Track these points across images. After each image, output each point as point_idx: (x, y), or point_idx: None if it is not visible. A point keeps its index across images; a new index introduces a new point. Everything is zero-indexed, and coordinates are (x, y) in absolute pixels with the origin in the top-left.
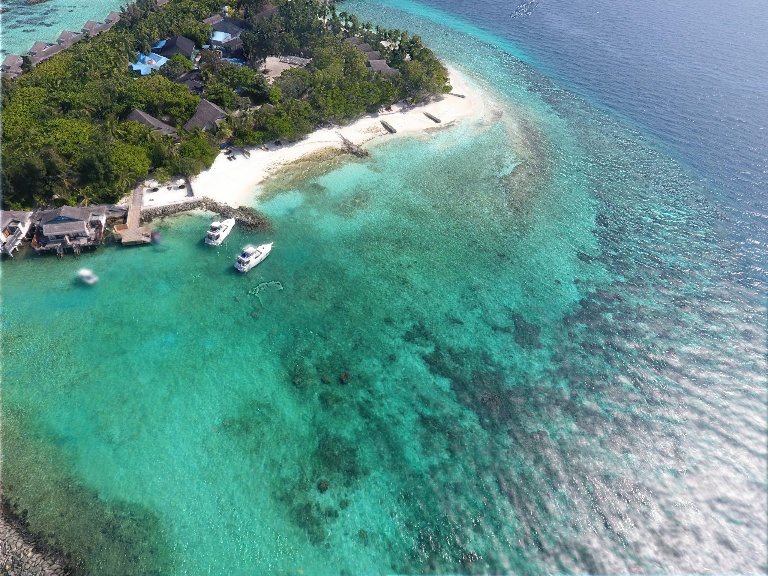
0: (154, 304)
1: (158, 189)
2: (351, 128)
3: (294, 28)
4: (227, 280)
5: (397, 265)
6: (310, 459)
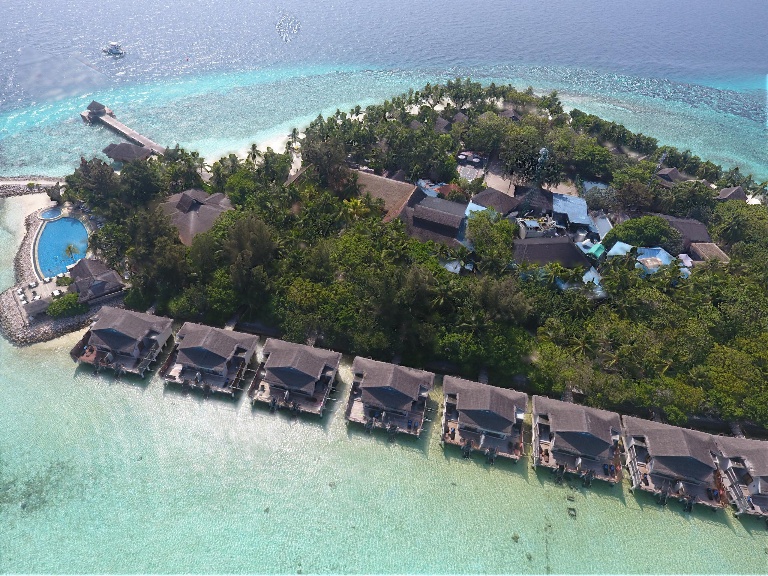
0: None
1: None
2: None
3: None
4: None
5: None
6: None
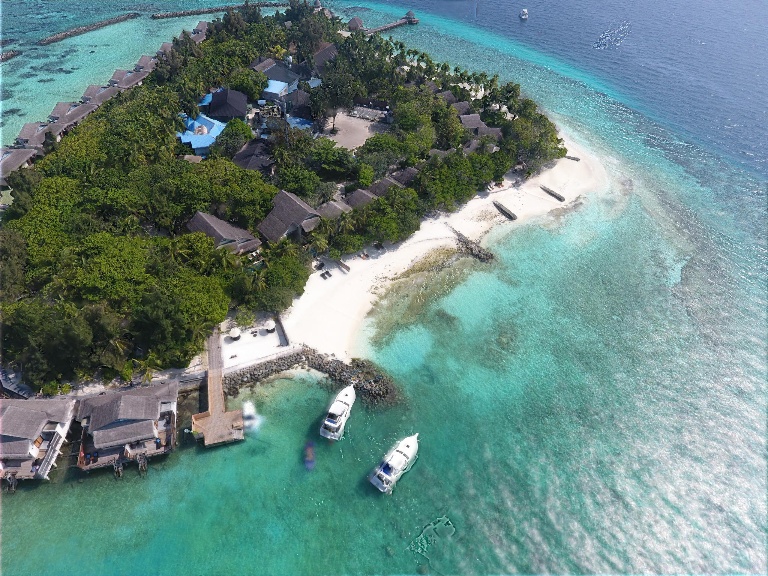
0: (269, 571)
1: (240, 336)
2: (461, 215)
3: (362, 74)
4: (365, 508)
5: (595, 462)
6: None
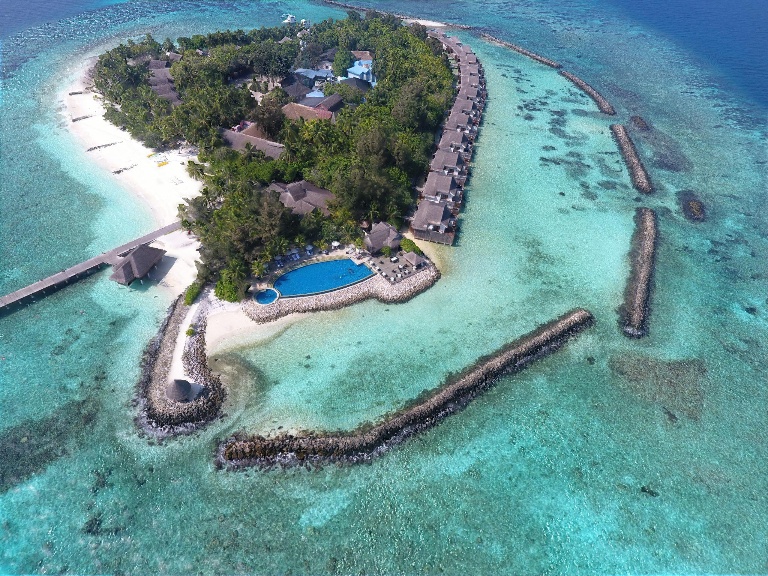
0: None
1: None
2: None
3: None
4: None
5: None
6: (279, 5)
